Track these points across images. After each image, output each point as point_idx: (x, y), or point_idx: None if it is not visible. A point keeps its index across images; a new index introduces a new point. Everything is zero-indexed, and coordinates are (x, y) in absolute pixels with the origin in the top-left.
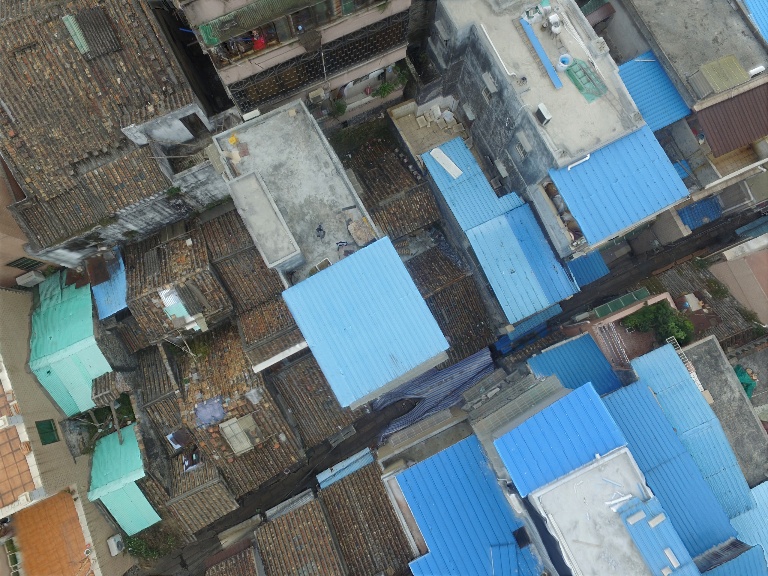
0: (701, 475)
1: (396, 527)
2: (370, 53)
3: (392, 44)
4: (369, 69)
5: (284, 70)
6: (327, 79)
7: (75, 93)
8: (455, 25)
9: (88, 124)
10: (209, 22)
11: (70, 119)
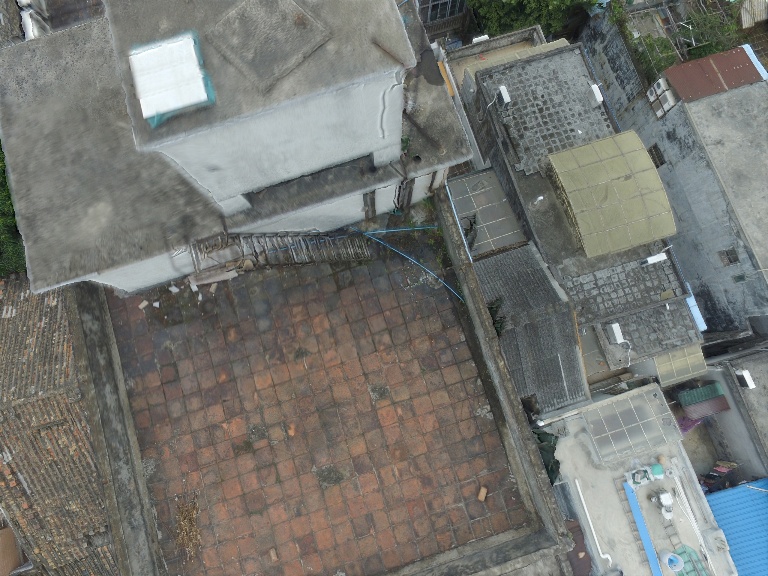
0: None
1: None
2: None
3: None
4: None
5: None
6: None
7: None
8: None
9: None
10: None
11: (91, 493)
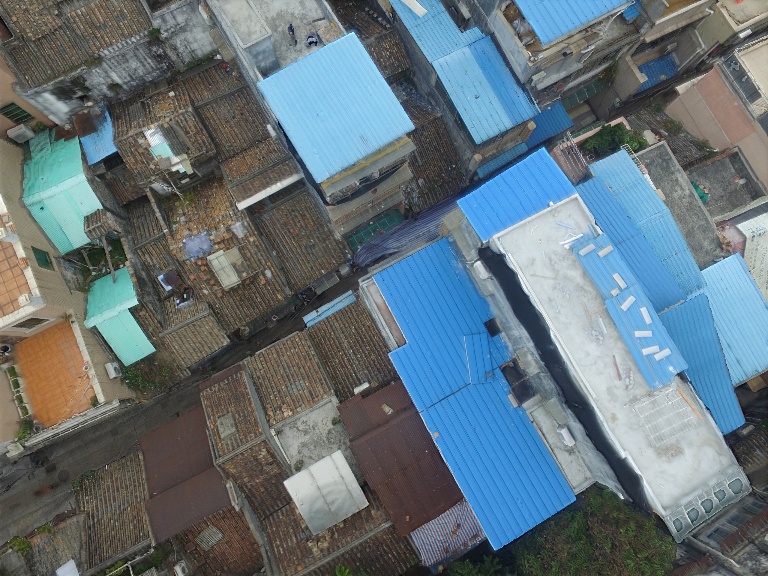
0: (653, 252)
1: (379, 350)
2: None
3: None
4: None
5: None
6: None
7: None
8: None
9: None
10: None
11: None
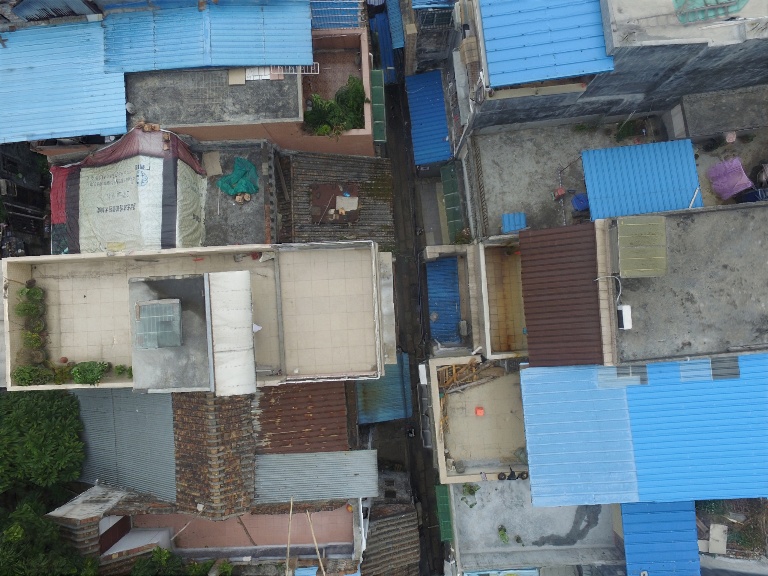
0: None
1: None
2: None
3: None
4: None
5: None
6: None
7: None
8: None
9: None
10: None
11: None
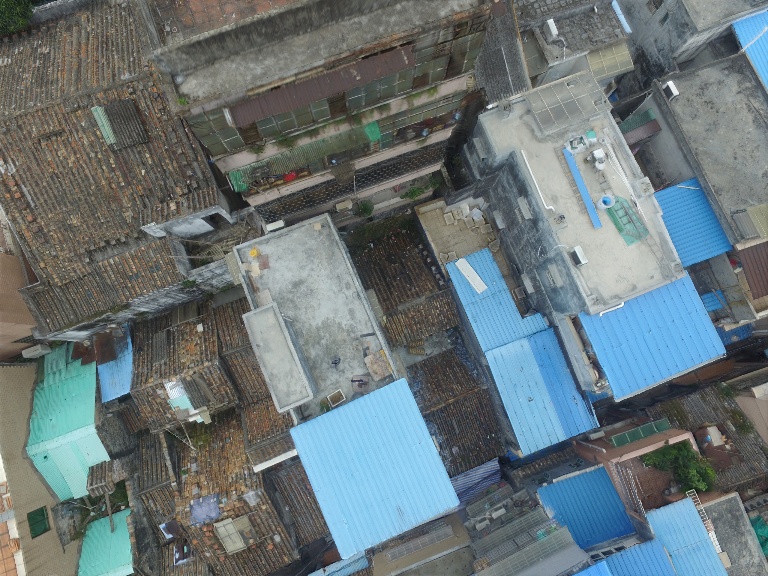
0: None
1: None
2: (403, 171)
3: (427, 163)
4: (400, 181)
5: (313, 191)
6: (356, 193)
7: (97, 182)
8: (494, 150)
9: (108, 213)
10: (240, 168)
11: (90, 207)
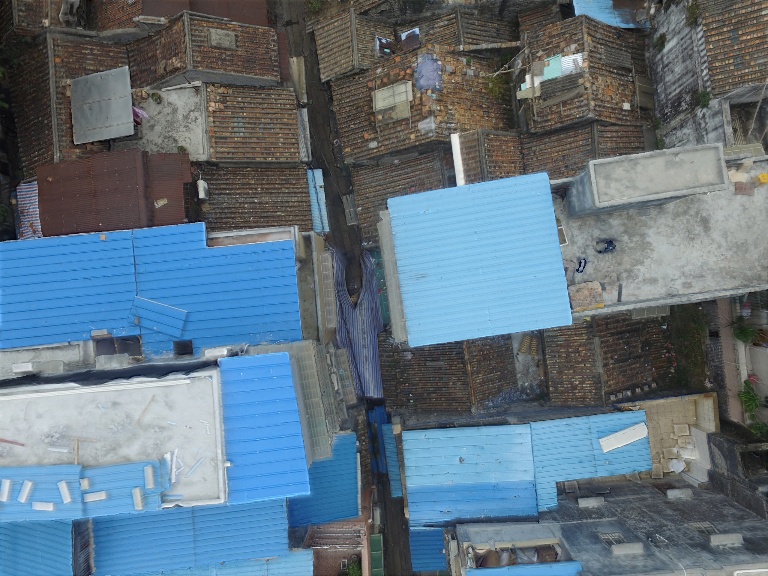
0: (166, 568)
1: None
2: None
3: None
4: None
5: None
6: None
7: None
8: None
9: None
10: None
11: None
